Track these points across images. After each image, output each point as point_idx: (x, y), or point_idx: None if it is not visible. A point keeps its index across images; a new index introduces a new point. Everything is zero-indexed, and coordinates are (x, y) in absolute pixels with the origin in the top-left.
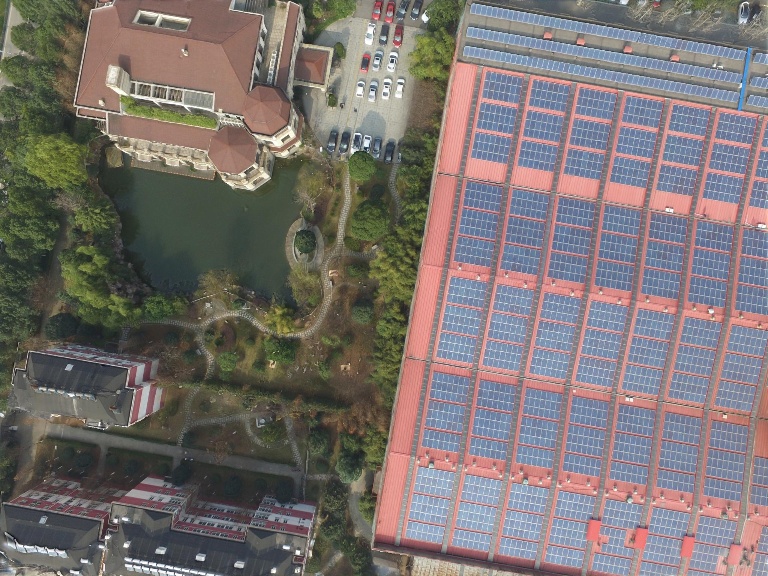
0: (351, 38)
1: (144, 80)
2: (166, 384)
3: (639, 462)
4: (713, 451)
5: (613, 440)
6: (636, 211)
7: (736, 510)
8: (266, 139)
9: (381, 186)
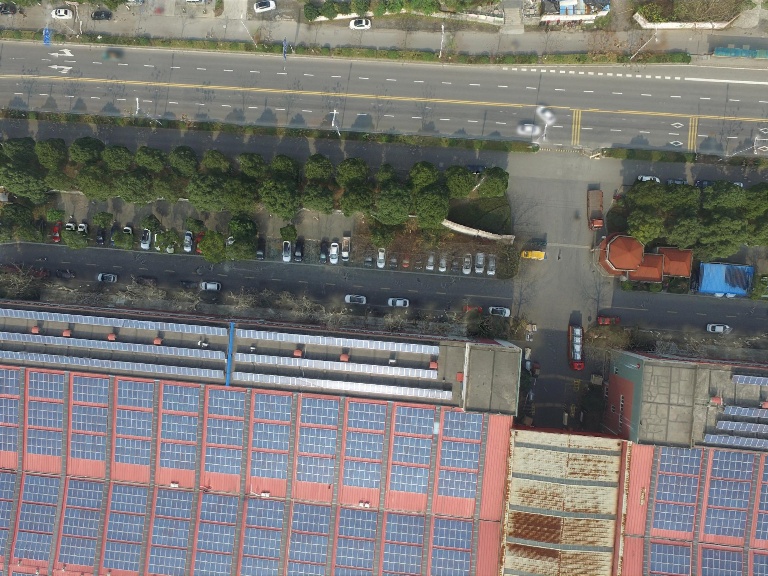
0: None
1: None
2: None
3: None
4: None
5: None
6: (143, 488)
7: None
8: None
9: None
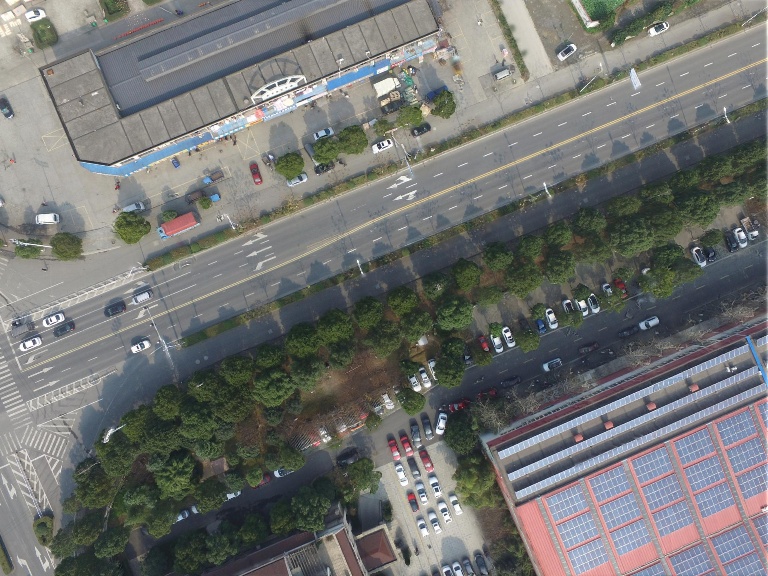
0: (387, 488)
1: None
2: None
3: None
4: None
5: None
6: (739, 528)
7: None
8: None
9: None
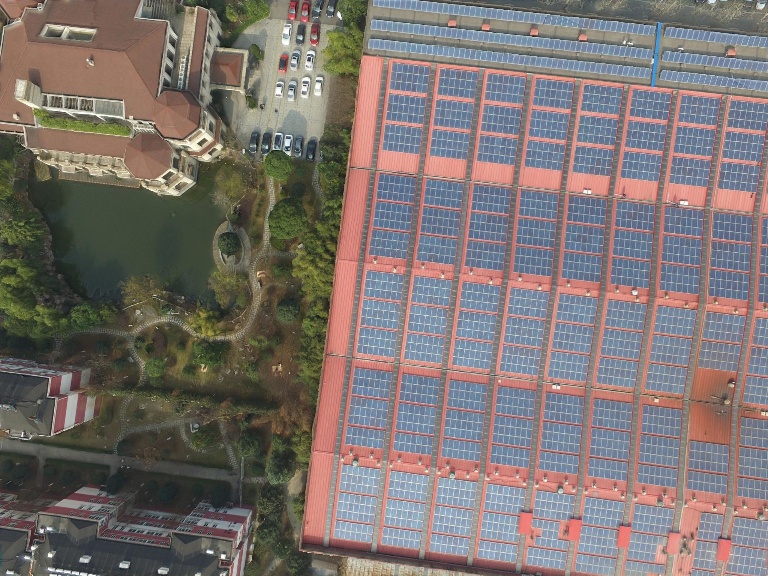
0: (268, 39)
1: (54, 92)
2: (96, 392)
3: (569, 451)
4: (646, 437)
5: (541, 429)
6: (553, 195)
7: (673, 497)
8: (181, 143)
9: (301, 184)
